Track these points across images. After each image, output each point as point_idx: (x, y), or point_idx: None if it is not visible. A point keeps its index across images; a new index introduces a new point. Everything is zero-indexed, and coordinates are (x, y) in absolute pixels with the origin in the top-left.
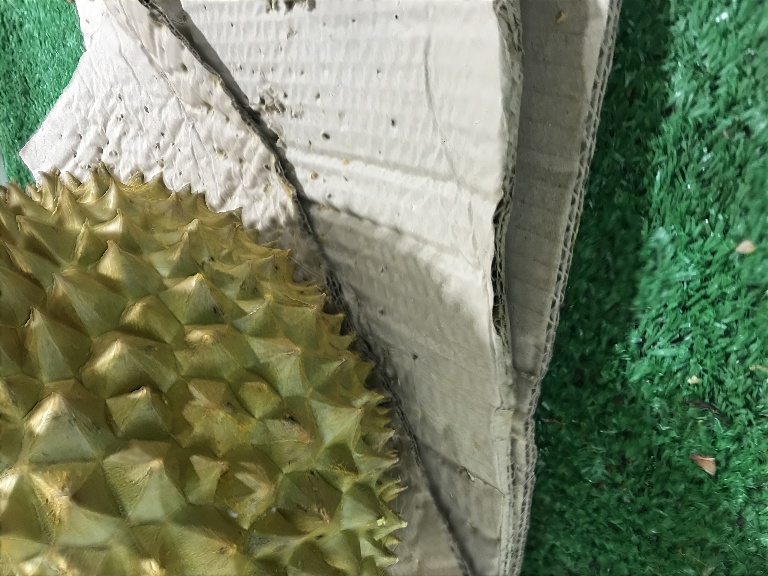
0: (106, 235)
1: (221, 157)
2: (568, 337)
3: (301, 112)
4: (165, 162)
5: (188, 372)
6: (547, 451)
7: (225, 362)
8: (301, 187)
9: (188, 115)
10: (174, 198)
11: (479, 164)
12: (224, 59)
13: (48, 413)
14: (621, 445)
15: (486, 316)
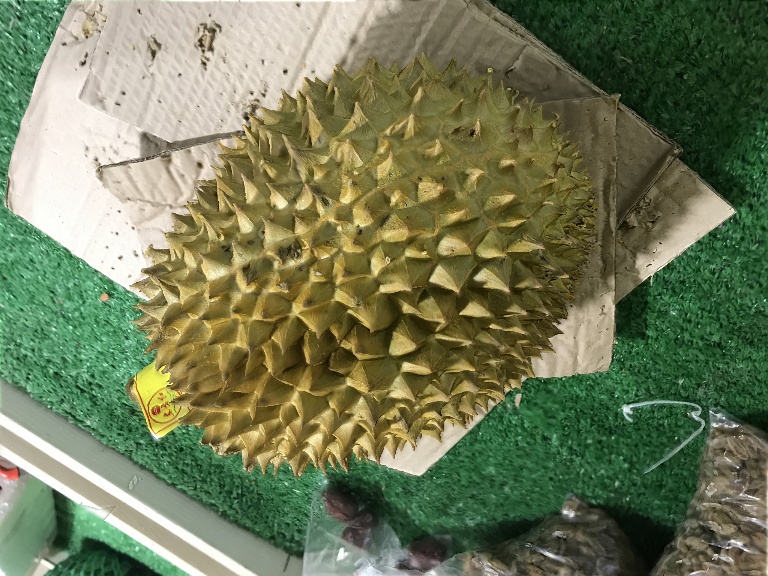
0: None
1: None
2: None
3: (265, 84)
4: None
5: None
6: (515, 16)
7: (354, 84)
8: None
9: None
10: None
11: None
12: (211, 132)
13: (316, 117)
14: None
15: None
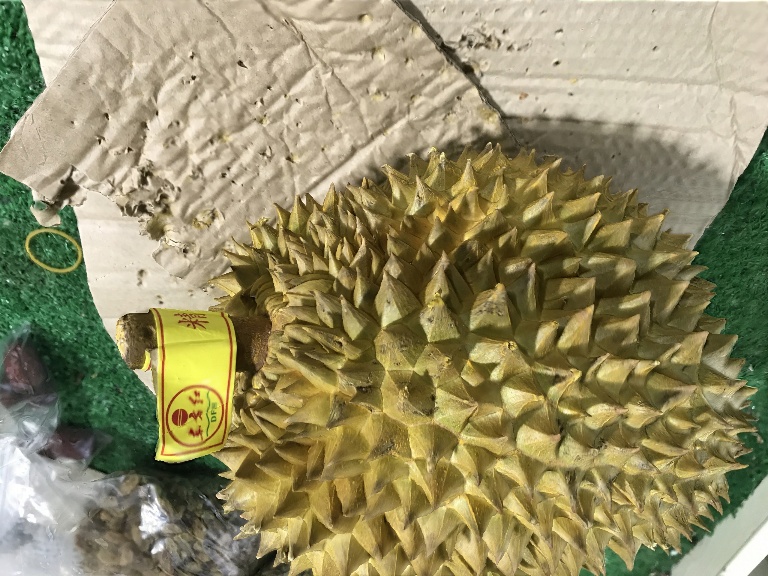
0: (582, 217)
1: (380, 98)
2: None
3: (530, 46)
4: (269, 117)
5: None
6: None
7: None
8: (499, 108)
9: (324, 62)
10: None
11: (764, 74)
12: (418, 2)
13: (703, 345)
14: (750, 207)
15: (732, 165)
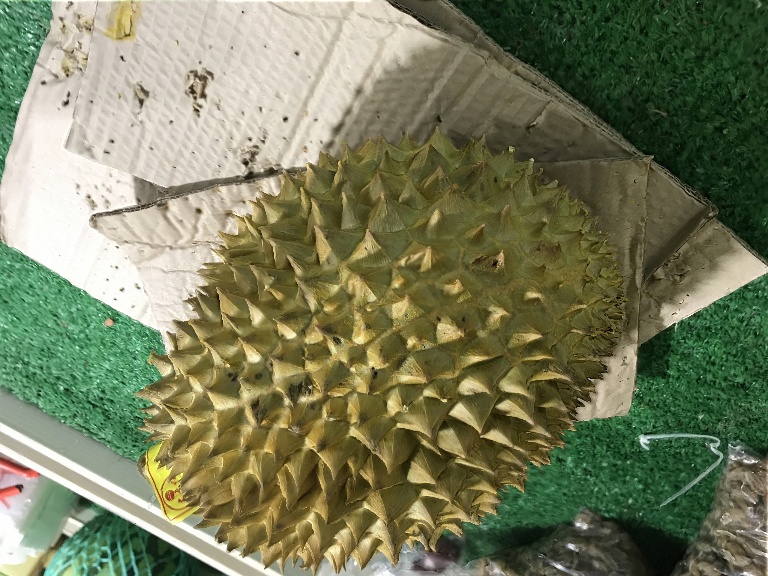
0: (258, 221)
1: None
2: (467, 8)
3: (264, 131)
4: None
5: (355, 194)
6: (538, 64)
7: (362, 173)
8: None
9: None
10: (263, 194)
11: None
12: (209, 177)
13: (323, 236)
14: (545, 4)
15: (424, 35)
